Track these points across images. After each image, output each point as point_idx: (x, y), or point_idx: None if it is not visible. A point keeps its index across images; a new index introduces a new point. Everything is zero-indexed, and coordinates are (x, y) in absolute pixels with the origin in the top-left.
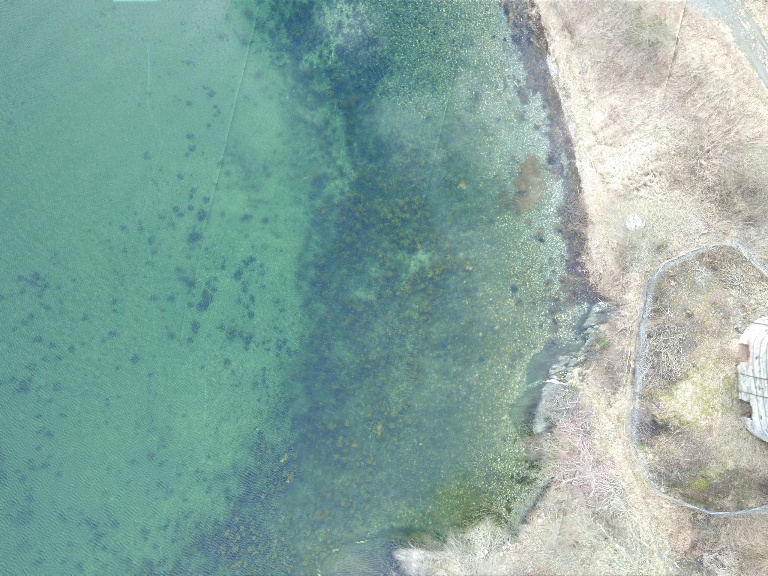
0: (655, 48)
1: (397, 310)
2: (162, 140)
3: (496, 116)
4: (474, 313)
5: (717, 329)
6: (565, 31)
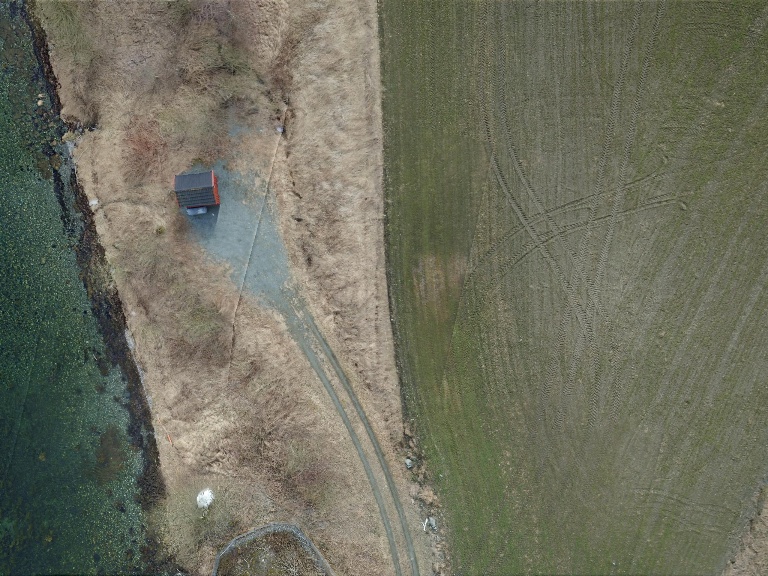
0: (217, 332)
1: None
2: None
3: (78, 387)
4: None
5: None
6: (141, 307)
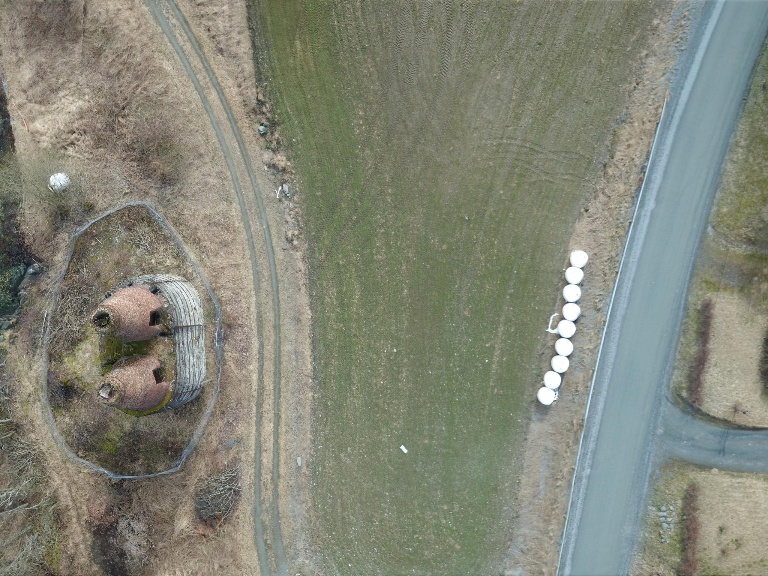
0: (69, 3)
1: None
2: None
3: None
4: None
5: None
6: None
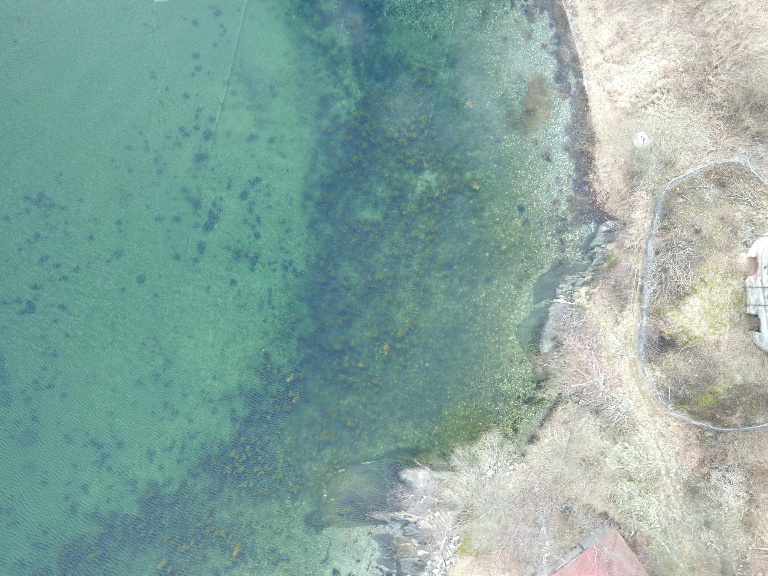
0: None
1: (403, 230)
2: (168, 59)
3: (503, 35)
4: (481, 233)
5: (725, 243)
6: None
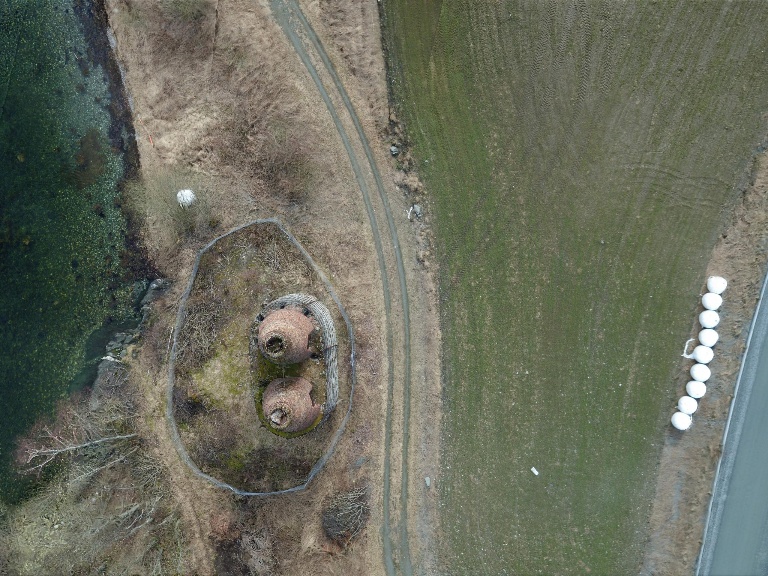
0: (200, 21)
1: None
2: None
3: (58, 89)
4: (34, 288)
5: (247, 306)
6: (123, 3)
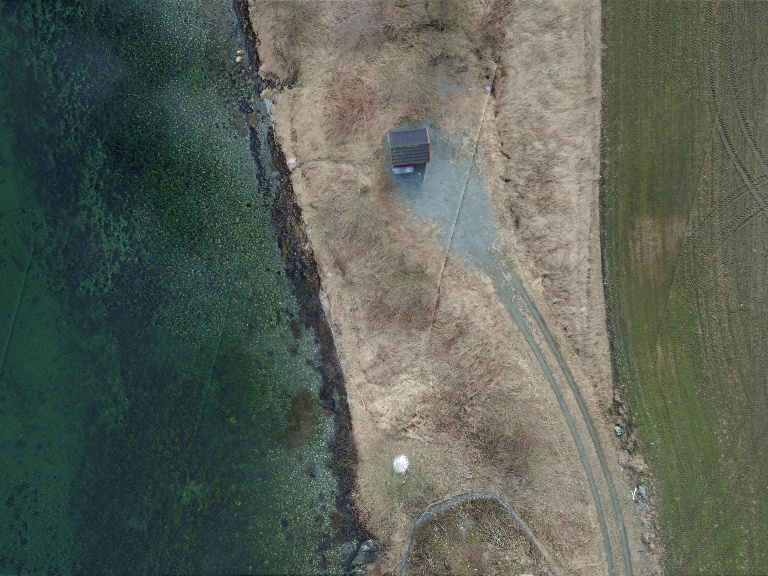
0: (419, 294)
1: (167, 542)
2: None
3: (269, 349)
4: (244, 547)
5: None
6: (337, 268)
